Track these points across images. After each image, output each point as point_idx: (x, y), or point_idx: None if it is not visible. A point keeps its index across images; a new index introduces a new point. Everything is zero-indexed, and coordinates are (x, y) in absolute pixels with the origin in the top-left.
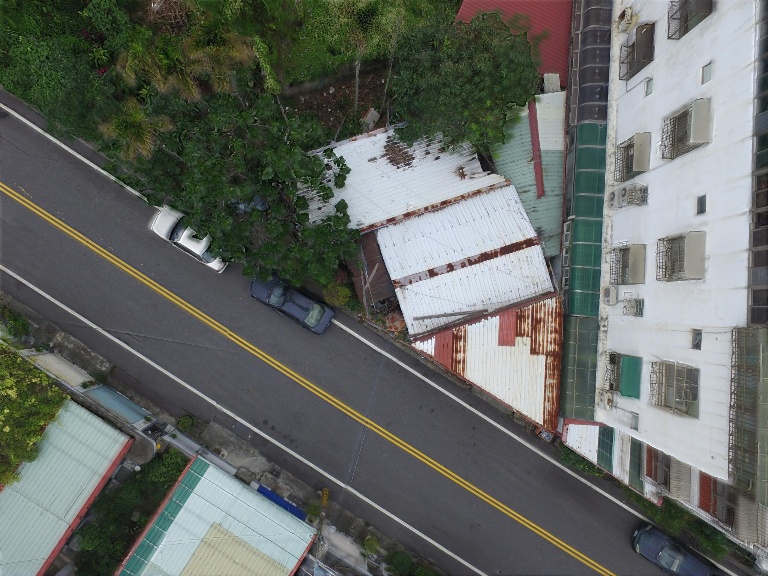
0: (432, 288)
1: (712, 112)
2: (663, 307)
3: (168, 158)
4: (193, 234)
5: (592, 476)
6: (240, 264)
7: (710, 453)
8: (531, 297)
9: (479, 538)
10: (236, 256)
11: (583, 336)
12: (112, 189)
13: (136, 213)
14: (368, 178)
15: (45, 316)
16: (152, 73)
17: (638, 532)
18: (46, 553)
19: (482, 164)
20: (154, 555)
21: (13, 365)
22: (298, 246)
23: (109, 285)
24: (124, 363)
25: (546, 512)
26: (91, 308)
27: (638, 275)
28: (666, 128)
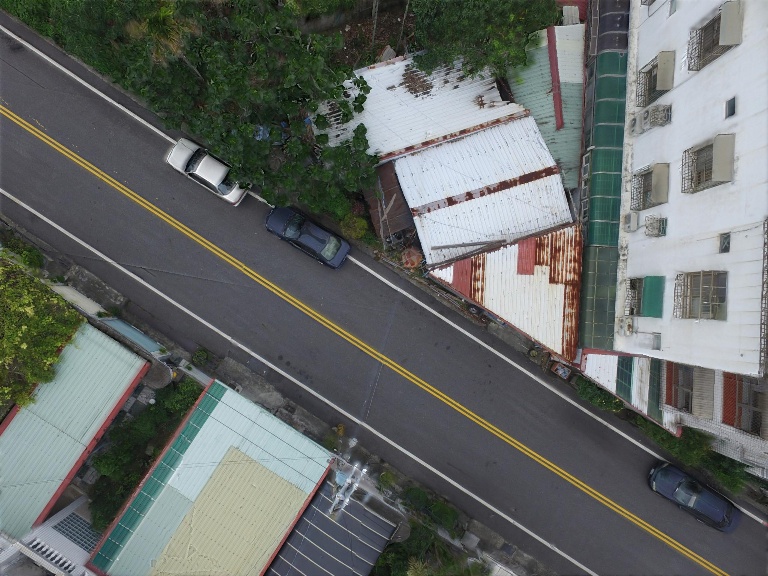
0: (450, 217)
1: (742, 13)
2: (688, 220)
3: (187, 75)
4: (209, 165)
5: (608, 415)
6: (255, 199)
7: (739, 351)
8: (550, 228)
9: (494, 476)
10: (255, 177)
11: (602, 266)
12: (127, 123)
13: (151, 147)
14: (386, 106)
15: (59, 249)
16: (168, 5)
17: (654, 470)
18: (63, 474)
19: (501, 93)
20: (171, 478)
21: (30, 284)
22: (317, 167)
23: (124, 219)
24: (138, 297)
25: (562, 450)
26: (106, 242)
27: (661, 195)
28: (691, 42)
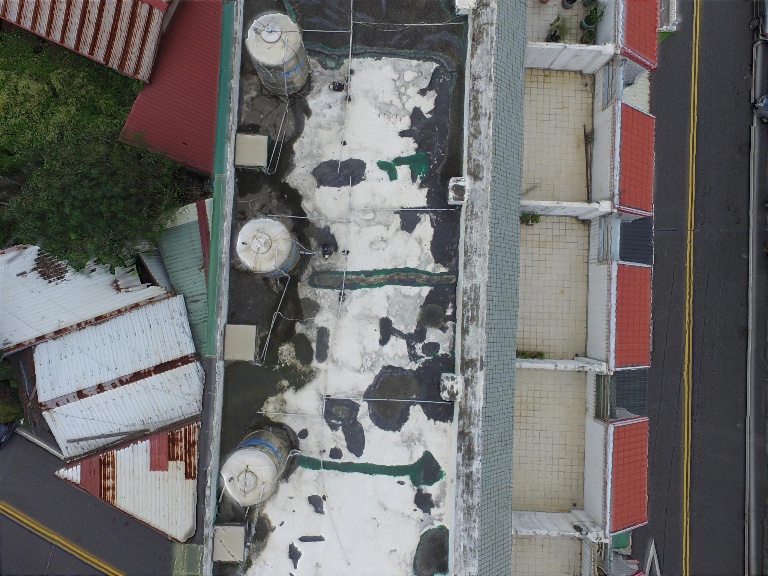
0: (84, 410)
1: None
2: None
3: None
4: None
5: None
6: None
7: None
8: (195, 415)
9: None
10: None
11: None
12: None
13: None
14: (16, 294)
15: None
16: None
17: None
18: None
19: (141, 276)
20: None
21: None
22: None
23: None
24: None
25: None
26: None
27: None
28: None
